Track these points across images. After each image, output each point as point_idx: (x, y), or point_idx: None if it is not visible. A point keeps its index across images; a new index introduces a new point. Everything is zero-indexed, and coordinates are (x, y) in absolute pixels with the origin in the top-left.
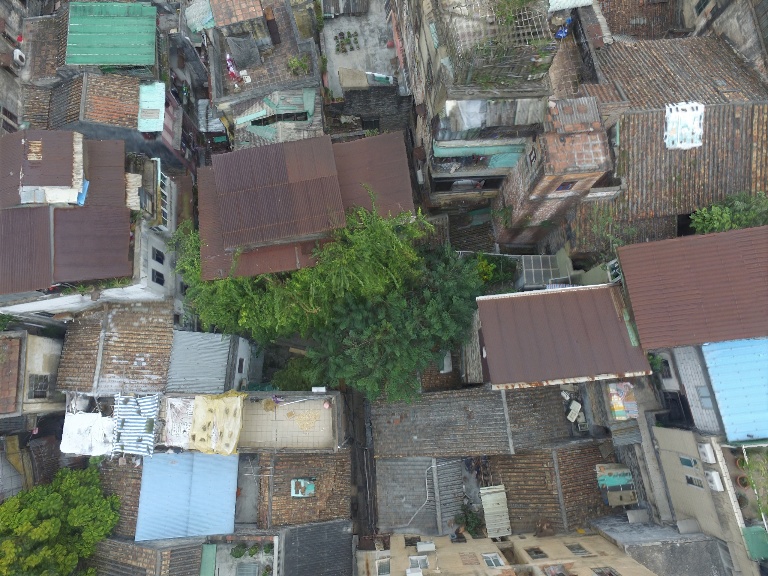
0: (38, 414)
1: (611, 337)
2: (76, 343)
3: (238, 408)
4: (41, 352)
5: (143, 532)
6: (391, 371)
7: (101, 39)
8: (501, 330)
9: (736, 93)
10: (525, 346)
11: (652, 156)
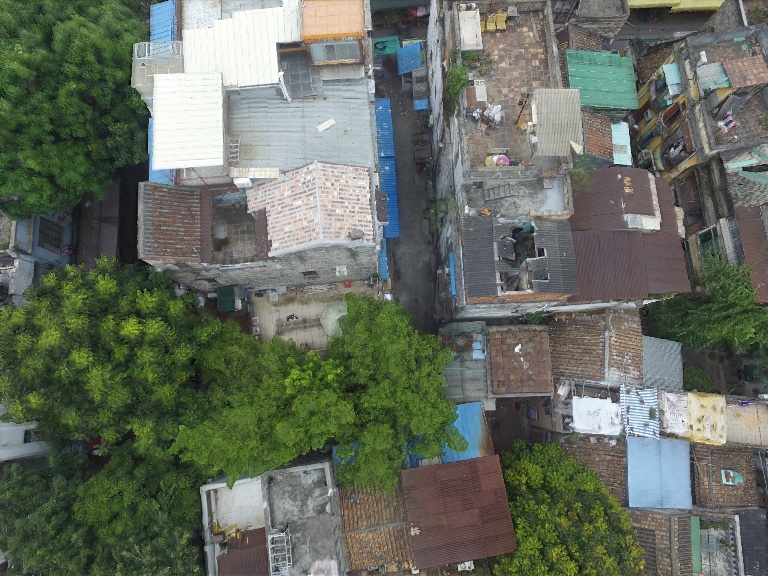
0: None
1: None
2: (567, 338)
3: (724, 406)
4: None
5: (634, 500)
6: None
7: (594, 84)
8: None
9: None
10: None
11: None
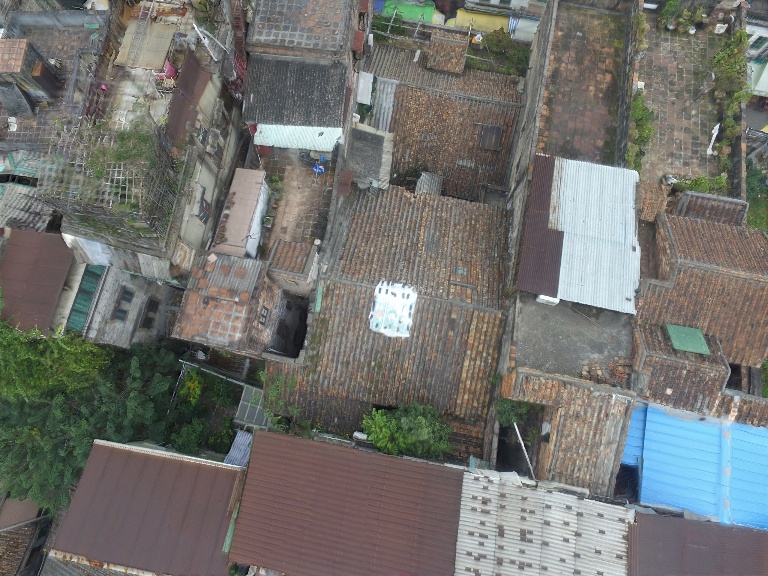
0: None
1: (207, 532)
2: None
3: None
4: None
5: None
6: (24, 481)
7: None
8: (98, 486)
9: (464, 289)
10: (112, 513)
11: (354, 333)
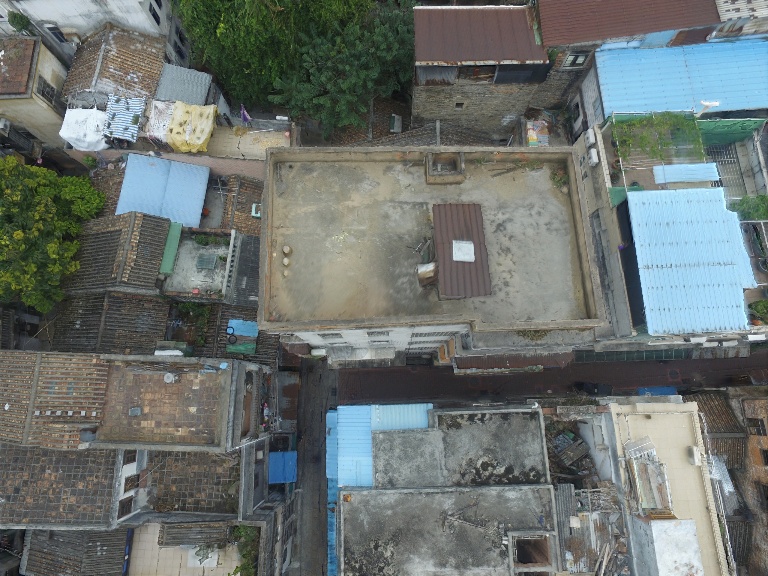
0: (43, 144)
1: (520, 39)
2: (81, 61)
3: (211, 113)
4: (51, 66)
5: (122, 211)
6: (341, 85)
7: None
8: (430, 29)
9: None
10: (448, 40)
11: None
